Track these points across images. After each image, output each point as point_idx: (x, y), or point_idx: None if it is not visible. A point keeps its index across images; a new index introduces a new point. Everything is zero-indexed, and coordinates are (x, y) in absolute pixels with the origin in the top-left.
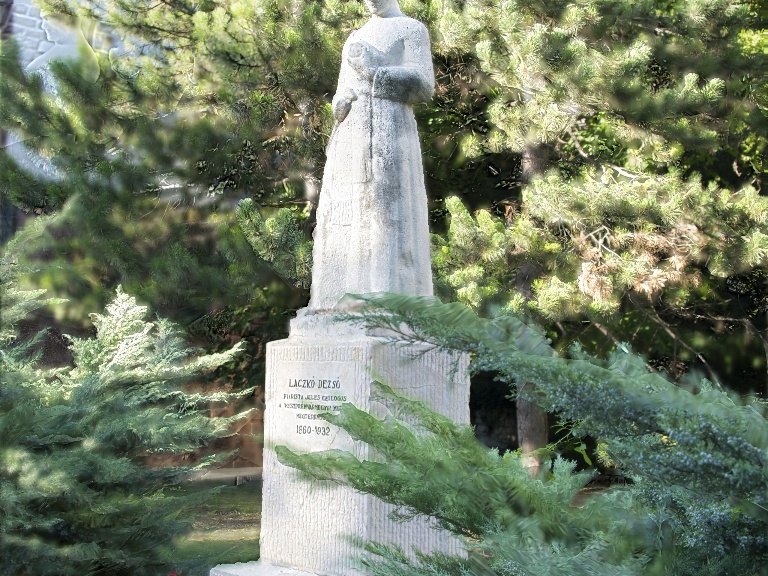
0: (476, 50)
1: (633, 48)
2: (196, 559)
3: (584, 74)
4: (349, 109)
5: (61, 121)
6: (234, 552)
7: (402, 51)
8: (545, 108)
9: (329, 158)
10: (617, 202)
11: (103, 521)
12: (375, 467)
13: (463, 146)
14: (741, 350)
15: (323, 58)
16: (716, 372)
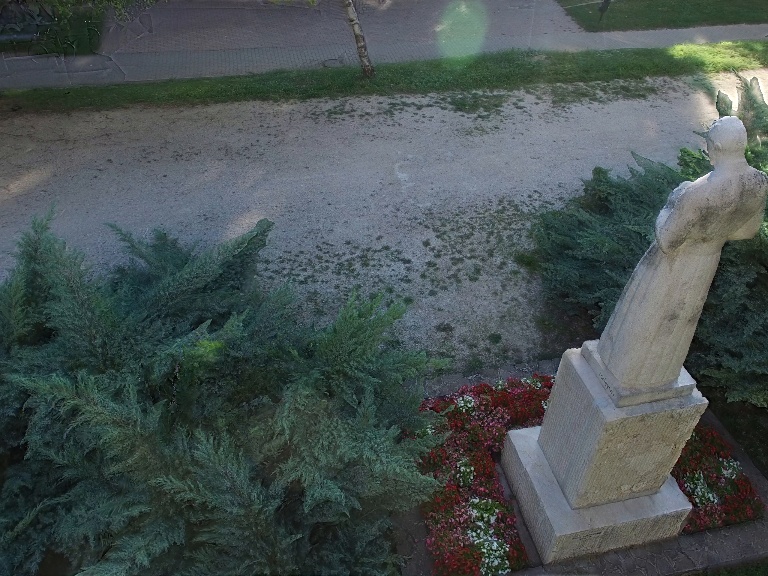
0: None
1: None
2: None
3: None
4: None
5: None
6: None
7: None
8: None
9: None
10: None
11: None
12: None
13: None
14: None
15: None
16: None
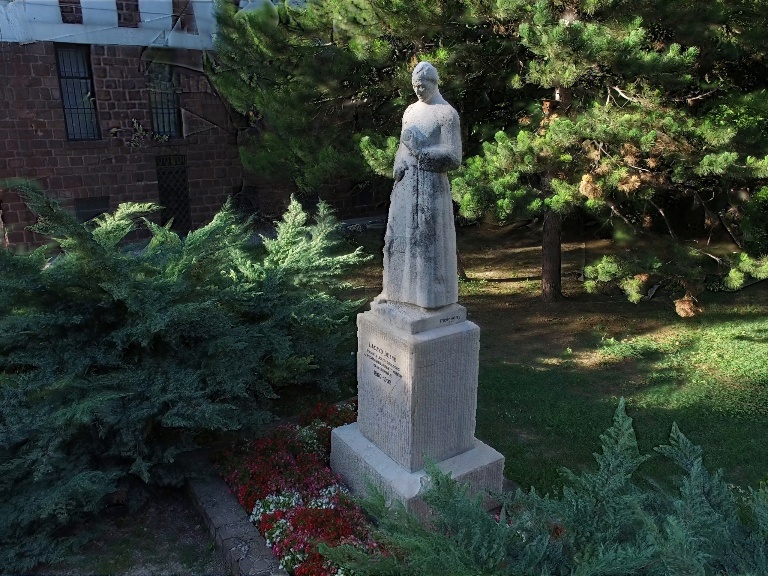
0: (519, 30)
1: (633, 30)
2: (342, 360)
3: (595, 49)
4: (404, 174)
5: (259, 54)
6: None
7: (440, 134)
8: (567, 64)
9: (392, 204)
10: (611, 135)
11: (279, 379)
12: (373, 574)
13: (512, 81)
14: (689, 213)
15: (420, 15)
16: (670, 224)
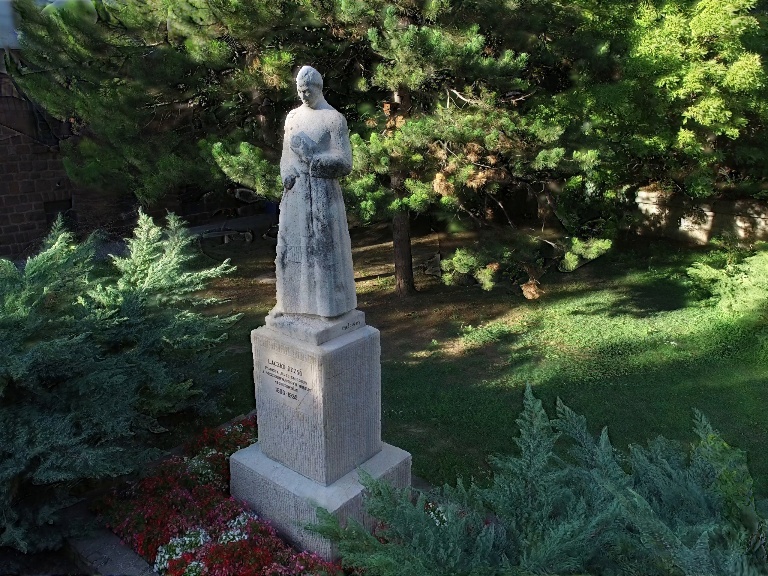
0: (368, 34)
1: (474, 36)
2: (214, 380)
3: (441, 54)
4: (294, 182)
5: (76, 54)
6: (232, 329)
7: (329, 140)
8: (414, 68)
9: (282, 213)
10: (459, 135)
11: (157, 411)
12: None
13: (359, 84)
14: (524, 204)
15: (259, 17)
16: (509, 215)
